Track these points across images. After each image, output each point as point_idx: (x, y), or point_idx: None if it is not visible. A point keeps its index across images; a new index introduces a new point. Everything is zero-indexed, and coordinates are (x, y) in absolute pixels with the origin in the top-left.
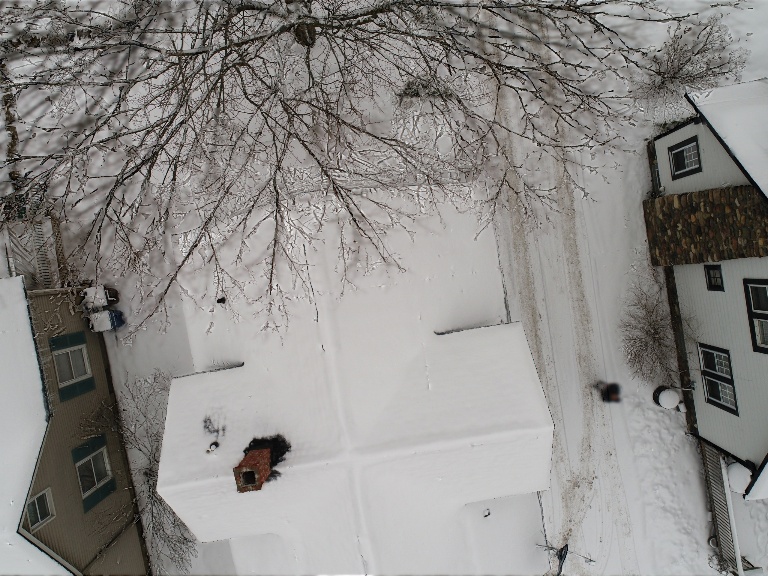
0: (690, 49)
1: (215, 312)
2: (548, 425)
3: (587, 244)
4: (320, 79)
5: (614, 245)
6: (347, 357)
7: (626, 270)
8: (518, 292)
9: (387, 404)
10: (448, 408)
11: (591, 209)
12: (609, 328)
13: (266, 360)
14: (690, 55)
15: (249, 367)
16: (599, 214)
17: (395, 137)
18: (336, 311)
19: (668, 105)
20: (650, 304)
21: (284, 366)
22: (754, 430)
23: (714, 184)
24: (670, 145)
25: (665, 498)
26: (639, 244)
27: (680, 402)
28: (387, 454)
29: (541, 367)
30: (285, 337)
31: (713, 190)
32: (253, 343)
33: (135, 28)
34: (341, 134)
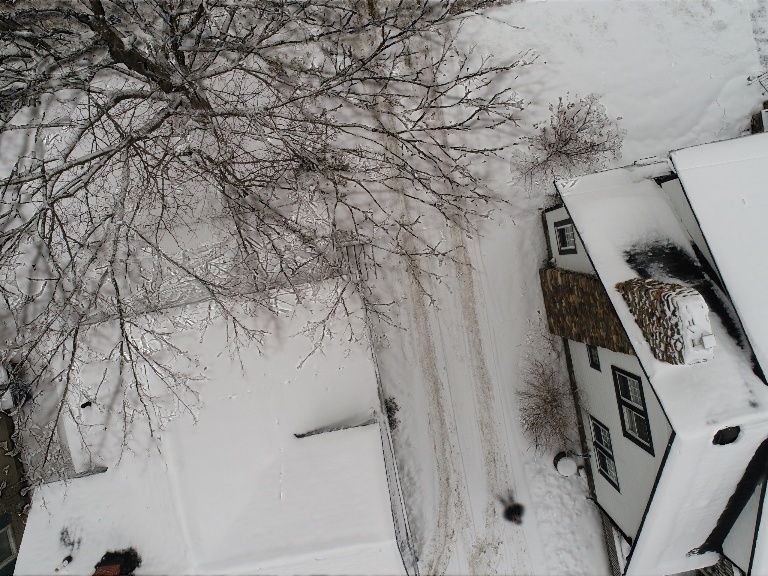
0: (574, 124)
1: (84, 413)
2: (389, 539)
3: (486, 313)
4: (177, 185)
5: (511, 314)
6: (192, 474)
7: (523, 339)
8: (419, 361)
9: (238, 515)
10: (296, 519)
11: (488, 278)
12: (509, 396)
13: (124, 469)
14: (576, 129)
15: (110, 474)
16: (496, 283)
17: (205, 278)
18: (179, 429)
19: (557, 177)
20: (548, 372)
21: (139, 477)
22: (631, 510)
23: (585, 269)
24: (555, 221)
25: (568, 562)
26: (536, 312)
27: (580, 468)
28: (232, 570)
29: (444, 435)
30: (137, 450)
31: (582, 277)
32: (114, 450)
33: (35, 104)
34: (163, 267)
